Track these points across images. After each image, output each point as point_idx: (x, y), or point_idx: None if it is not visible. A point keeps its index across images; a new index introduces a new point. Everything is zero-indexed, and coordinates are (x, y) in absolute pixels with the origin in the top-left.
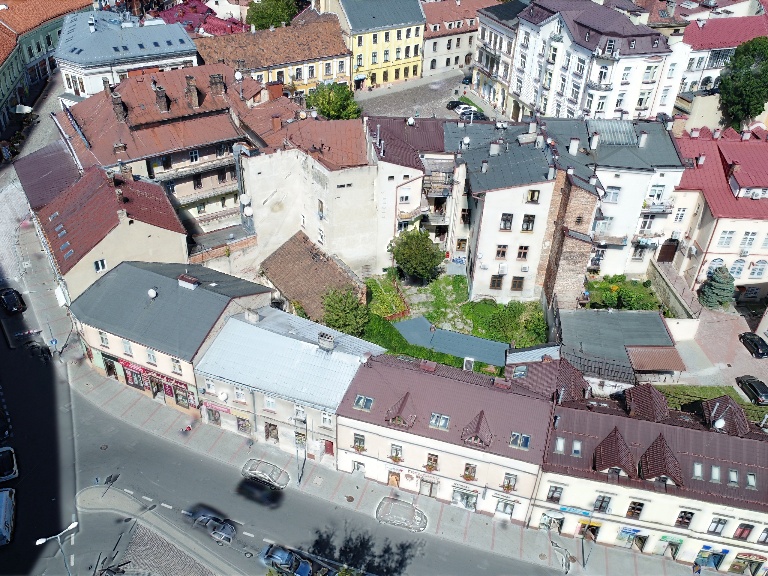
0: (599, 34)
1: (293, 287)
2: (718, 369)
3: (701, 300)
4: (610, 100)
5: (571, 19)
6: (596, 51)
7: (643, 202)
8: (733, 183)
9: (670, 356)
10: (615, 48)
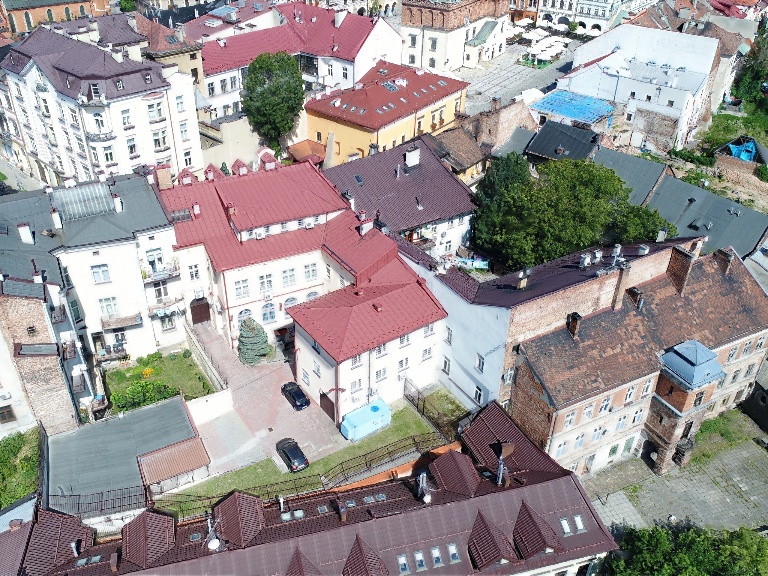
0: (79, 79)
1: None
2: (258, 439)
3: (241, 358)
4: (119, 149)
5: (48, 65)
6: (79, 99)
7: (140, 273)
8: (234, 227)
9: (192, 451)
10: (100, 92)
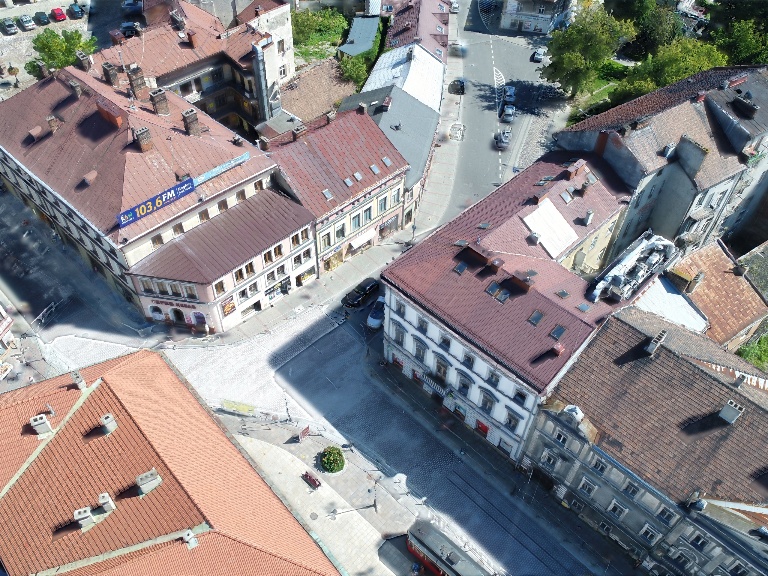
0: None
1: (320, 106)
2: None
3: None
4: None
5: None
6: None
7: None
8: None
9: None
10: None
